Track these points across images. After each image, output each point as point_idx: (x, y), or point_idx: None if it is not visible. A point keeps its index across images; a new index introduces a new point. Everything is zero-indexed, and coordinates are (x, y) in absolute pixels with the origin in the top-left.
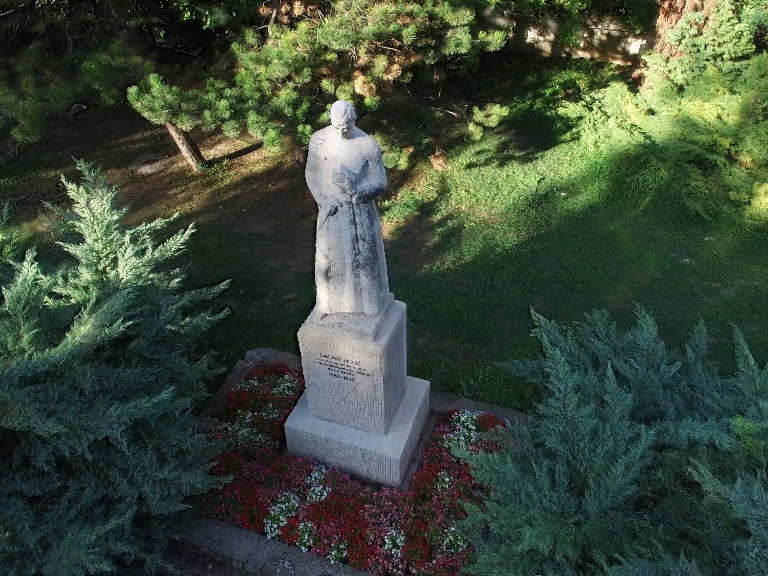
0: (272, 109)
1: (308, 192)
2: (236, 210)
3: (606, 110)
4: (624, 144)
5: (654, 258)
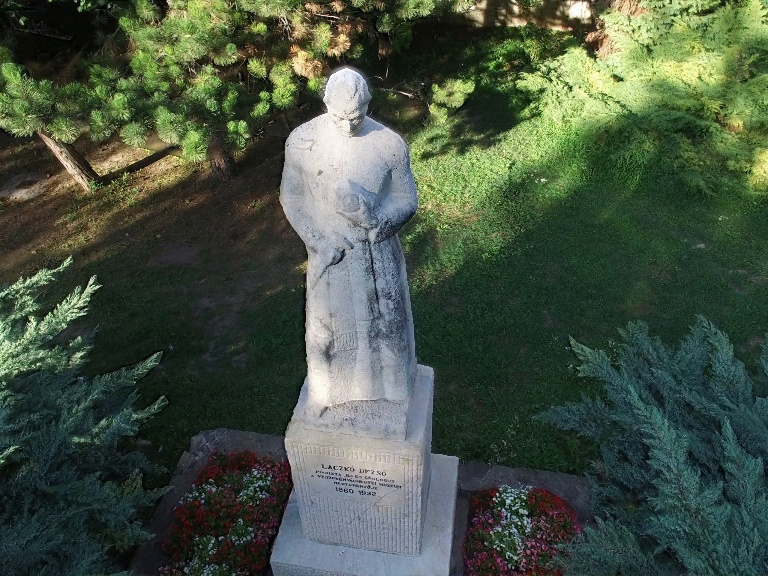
0: (188, 103)
1: (237, 205)
2: (148, 237)
3: (566, 80)
4: (604, 116)
5: (665, 247)
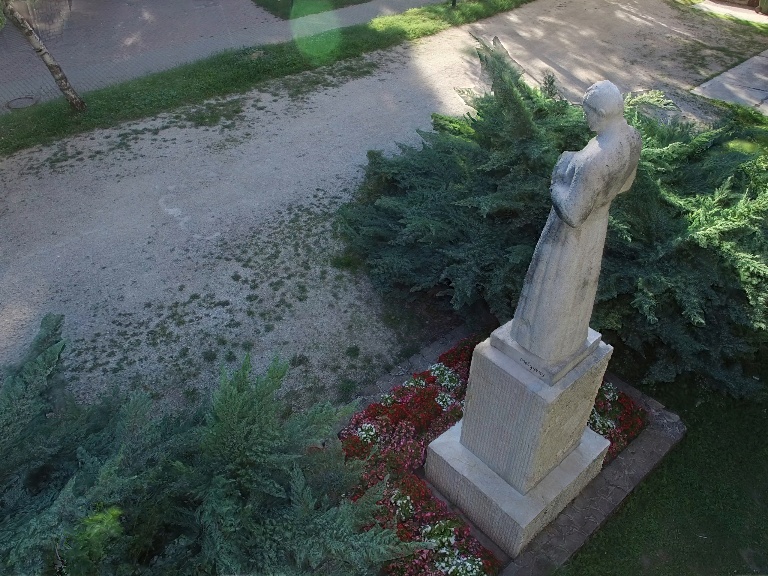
0: None
1: None
2: None
3: None
4: None
5: None
